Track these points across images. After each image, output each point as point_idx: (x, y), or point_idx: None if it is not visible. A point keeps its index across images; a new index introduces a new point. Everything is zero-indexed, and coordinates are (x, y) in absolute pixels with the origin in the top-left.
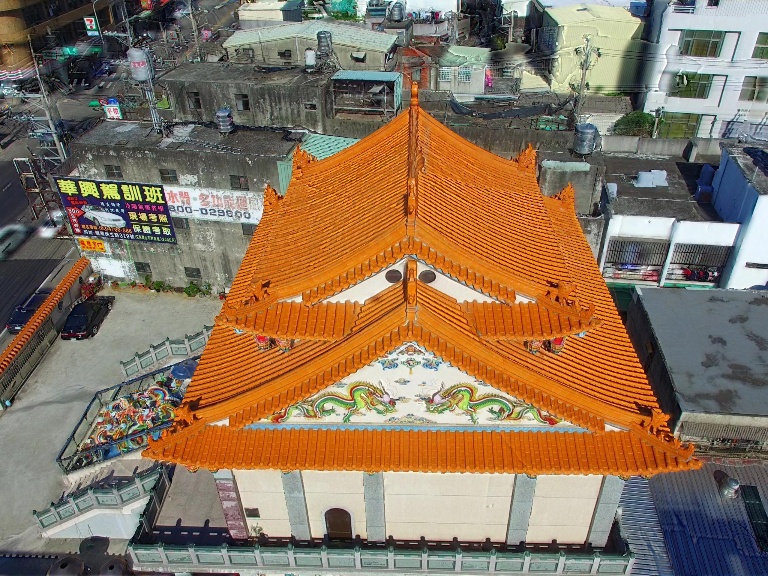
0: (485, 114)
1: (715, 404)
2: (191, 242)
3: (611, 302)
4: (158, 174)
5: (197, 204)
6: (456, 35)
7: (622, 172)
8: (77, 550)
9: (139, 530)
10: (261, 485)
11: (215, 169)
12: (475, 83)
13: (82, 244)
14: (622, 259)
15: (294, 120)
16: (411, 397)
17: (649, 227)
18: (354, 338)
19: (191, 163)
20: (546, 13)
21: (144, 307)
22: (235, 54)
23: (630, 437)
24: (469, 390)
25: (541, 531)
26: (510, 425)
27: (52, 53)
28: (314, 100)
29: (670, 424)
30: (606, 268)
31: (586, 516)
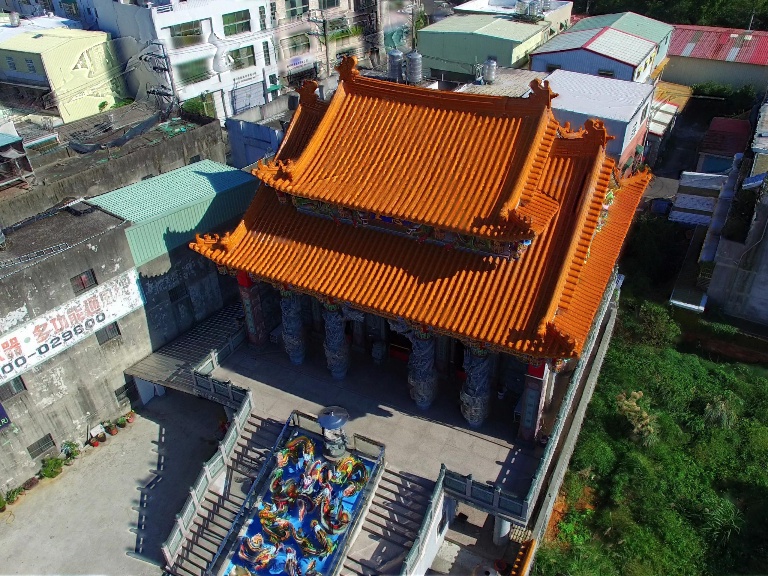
0: (112, 142)
1: None
2: (31, 405)
3: None
4: None
5: (31, 346)
6: None
7: None
8: None
9: (508, 496)
10: None
11: (49, 282)
12: None
13: None
14: None
15: None
16: None
17: None
18: (590, 188)
19: (13, 293)
20: None
21: (20, 533)
22: None
23: None
24: None
25: None
26: None
27: None
28: None
29: None
30: None
31: None
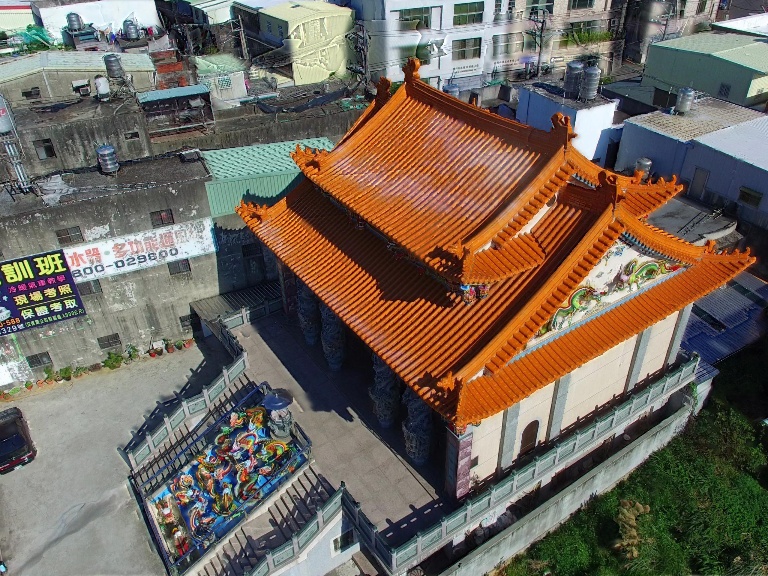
0: (294, 108)
1: None
2: (104, 306)
3: None
4: (54, 238)
5: (110, 258)
6: (191, 46)
7: None
8: None
9: None
10: (486, 429)
11: (131, 211)
12: (237, 88)
13: None
14: None
15: None
16: (601, 287)
17: None
18: (578, 248)
19: (99, 212)
20: (262, 14)
21: (68, 401)
22: None
23: (705, 263)
24: (635, 264)
25: (643, 370)
26: (649, 284)
27: None
28: (135, 128)
29: None
30: None
31: (667, 343)
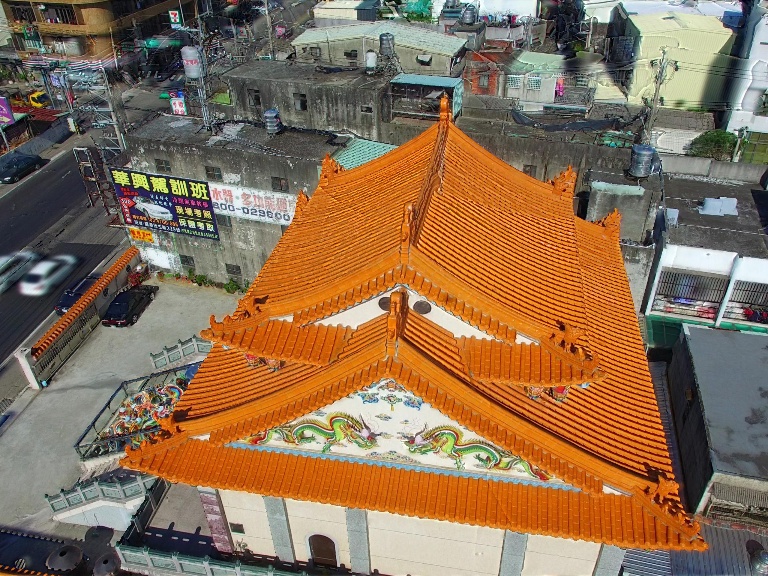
0: (547, 125)
1: (754, 467)
2: (233, 240)
3: (640, 345)
4: (204, 171)
5: (239, 203)
6: (530, 40)
7: (688, 197)
8: (83, 537)
9: (129, 530)
10: (245, 502)
11: (257, 169)
12: (545, 91)
13: (133, 233)
14: (675, 292)
15: (350, 122)
16: (393, 434)
17: (707, 260)
18: (333, 368)
19: (235, 162)
20: (629, 20)
21: (184, 300)
22: (303, 52)
23: (631, 503)
24: (454, 433)
25: None
26: (499, 474)
27: (130, 45)
28: (370, 103)
29: (701, 482)
30: (657, 300)
31: None
